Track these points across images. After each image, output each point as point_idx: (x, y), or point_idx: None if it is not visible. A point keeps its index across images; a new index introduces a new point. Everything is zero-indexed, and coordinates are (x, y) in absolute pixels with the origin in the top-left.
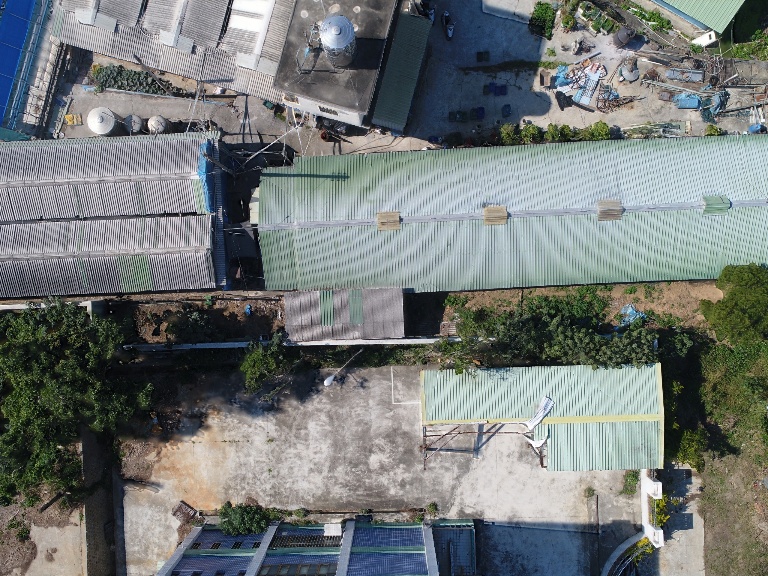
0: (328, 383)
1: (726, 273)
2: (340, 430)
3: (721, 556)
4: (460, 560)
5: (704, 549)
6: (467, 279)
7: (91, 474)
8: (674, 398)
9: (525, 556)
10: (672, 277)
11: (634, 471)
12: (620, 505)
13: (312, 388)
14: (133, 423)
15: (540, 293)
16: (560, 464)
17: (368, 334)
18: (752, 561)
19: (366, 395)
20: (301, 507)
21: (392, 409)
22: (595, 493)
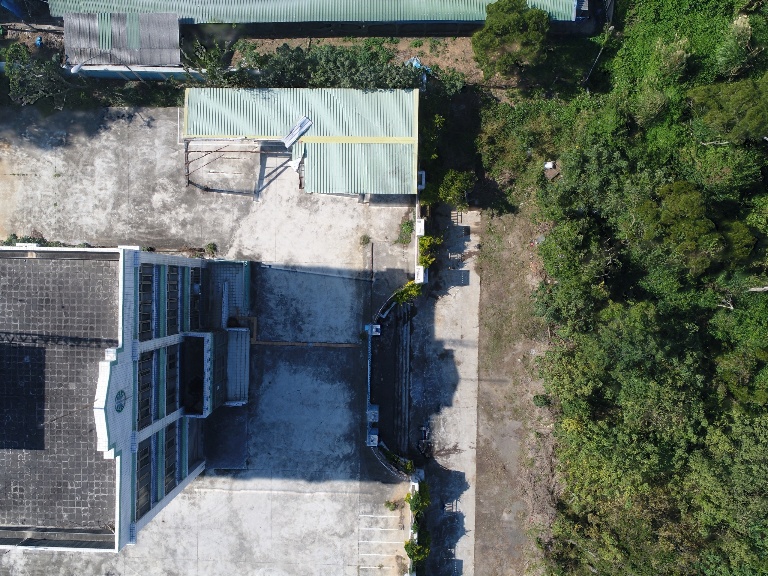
0: (74, 70)
1: (489, 5)
2: (125, 168)
3: (495, 314)
4: (236, 301)
5: (479, 306)
6: (244, 10)
7: None
8: (435, 130)
9: (299, 300)
10: (444, 17)
11: (409, 220)
12: (395, 254)
13: (100, 125)
14: None
15: (328, 43)
16: (317, 185)
17: (145, 60)
18: (525, 320)
19: (152, 134)
20: (84, 242)
21: (177, 149)
22: (371, 241)
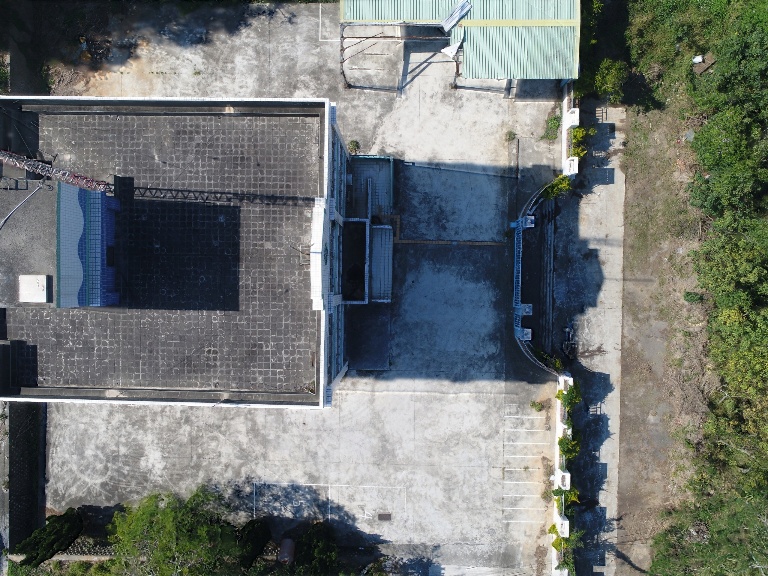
0: None
1: None
2: (266, 65)
3: (641, 212)
4: (379, 199)
5: (624, 205)
6: None
7: (18, 92)
8: (594, 16)
9: (443, 198)
10: None
11: (556, 116)
12: (541, 150)
13: (241, 22)
14: (63, 48)
15: None
16: (475, 71)
17: None
18: (672, 218)
19: (293, 31)
20: None
21: (318, 46)
22: (516, 137)
